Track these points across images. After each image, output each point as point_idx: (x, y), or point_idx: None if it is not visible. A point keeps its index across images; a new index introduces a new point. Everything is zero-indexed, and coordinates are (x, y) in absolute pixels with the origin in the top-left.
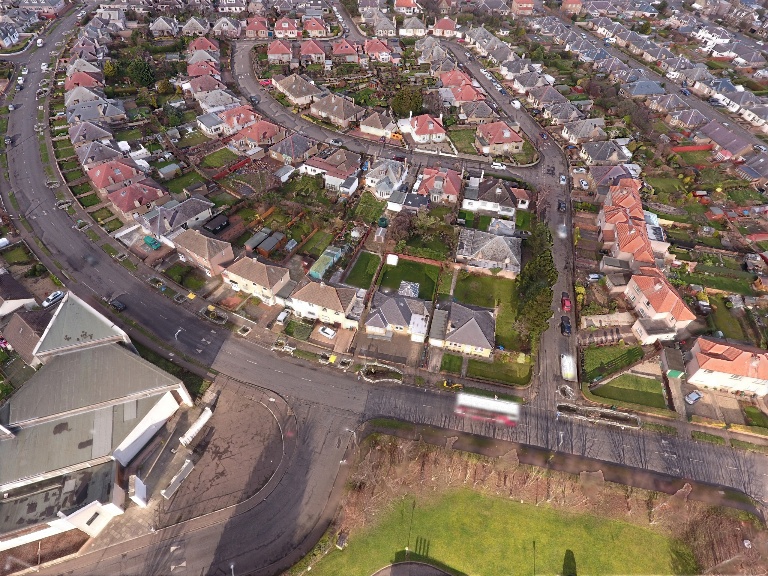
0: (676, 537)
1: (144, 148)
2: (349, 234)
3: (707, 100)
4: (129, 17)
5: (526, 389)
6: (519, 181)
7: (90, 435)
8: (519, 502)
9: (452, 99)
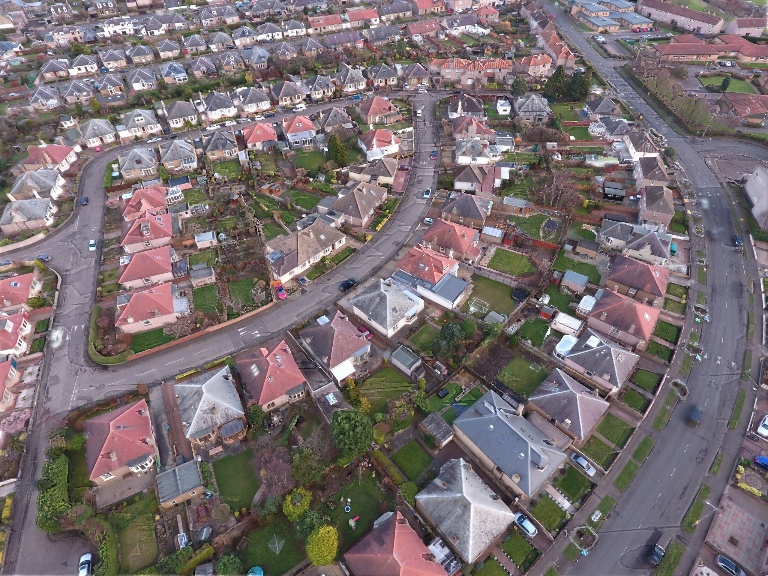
0: None
1: None
2: None
3: (264, 42)
4: None
5: None
6: (439, 103)
7: None
8: None
9: (312, 132)
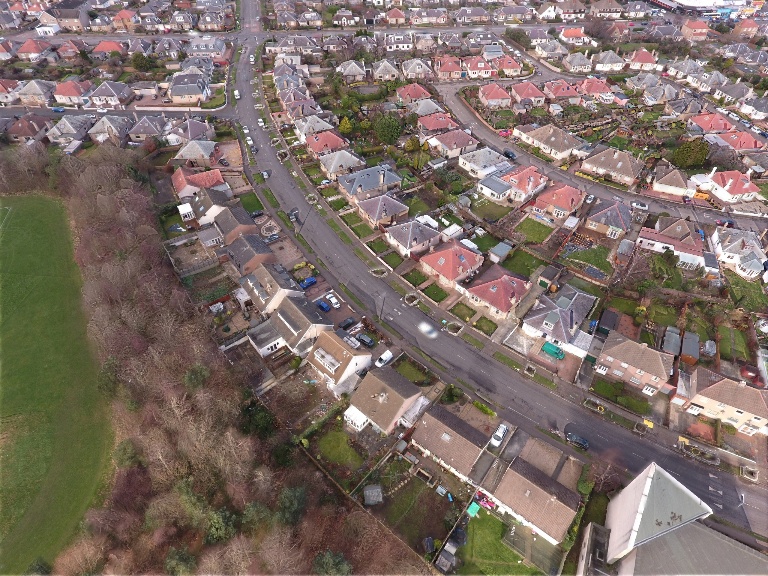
0: None
1: (452, 223)
2: (756, 328)
3: None
4: (305, 60)
5: None
6: None
7: None
8: None
9: None
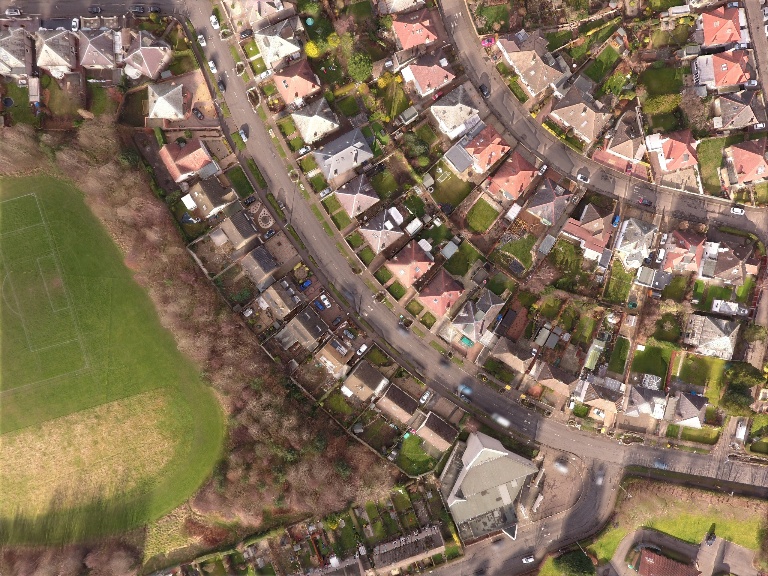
0: (764, 517)
1: None
2: (606, 318)
3: None
4: None
5: (713, 445)
6: (753, 238)
7: (499, 495)
8: None
9: (711, 83)
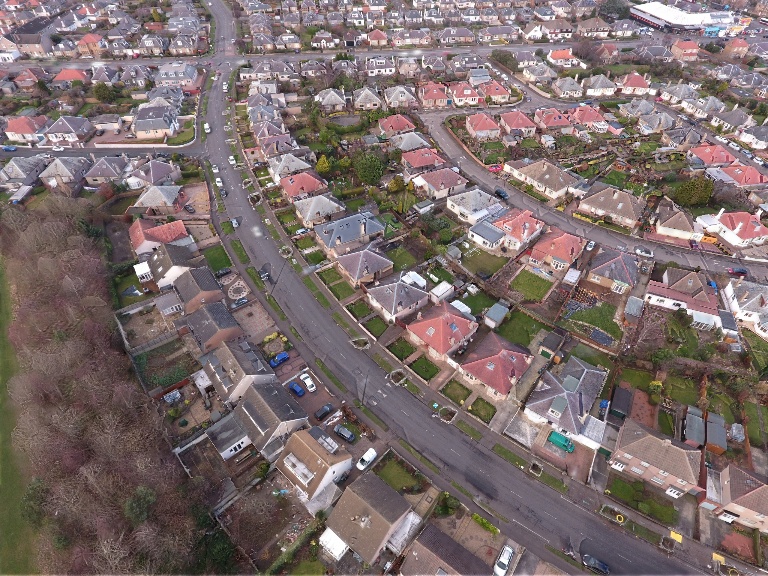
0: None
1: (441, 280)
2: None
3: None
4: (281, 88)
5: None
6: None
7: None
8: None
9: None
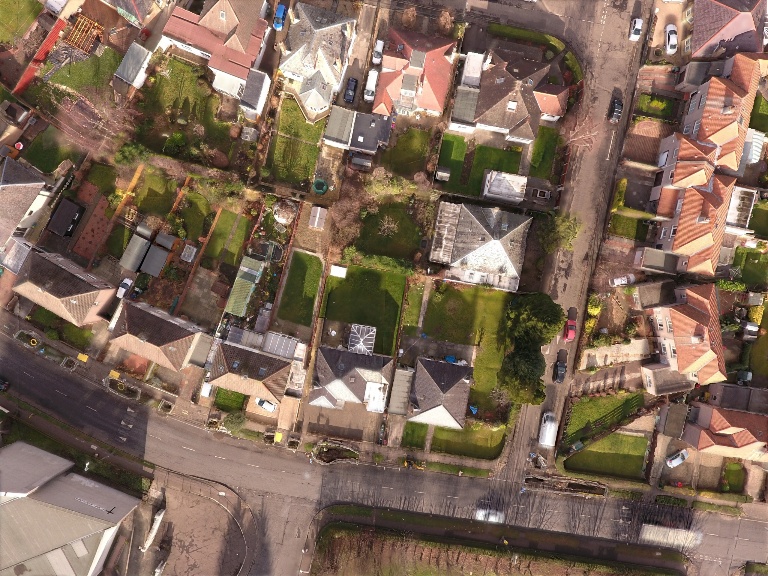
0: None
1: None
2: (271, 214)
3: None
4: None
5: None
6: (555, 46)
7: (52, 573)
8: (468, 574)
9: None
